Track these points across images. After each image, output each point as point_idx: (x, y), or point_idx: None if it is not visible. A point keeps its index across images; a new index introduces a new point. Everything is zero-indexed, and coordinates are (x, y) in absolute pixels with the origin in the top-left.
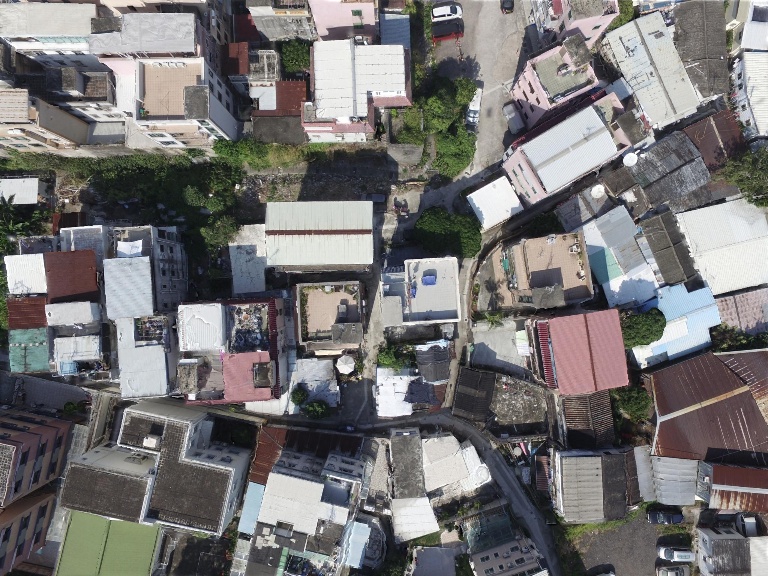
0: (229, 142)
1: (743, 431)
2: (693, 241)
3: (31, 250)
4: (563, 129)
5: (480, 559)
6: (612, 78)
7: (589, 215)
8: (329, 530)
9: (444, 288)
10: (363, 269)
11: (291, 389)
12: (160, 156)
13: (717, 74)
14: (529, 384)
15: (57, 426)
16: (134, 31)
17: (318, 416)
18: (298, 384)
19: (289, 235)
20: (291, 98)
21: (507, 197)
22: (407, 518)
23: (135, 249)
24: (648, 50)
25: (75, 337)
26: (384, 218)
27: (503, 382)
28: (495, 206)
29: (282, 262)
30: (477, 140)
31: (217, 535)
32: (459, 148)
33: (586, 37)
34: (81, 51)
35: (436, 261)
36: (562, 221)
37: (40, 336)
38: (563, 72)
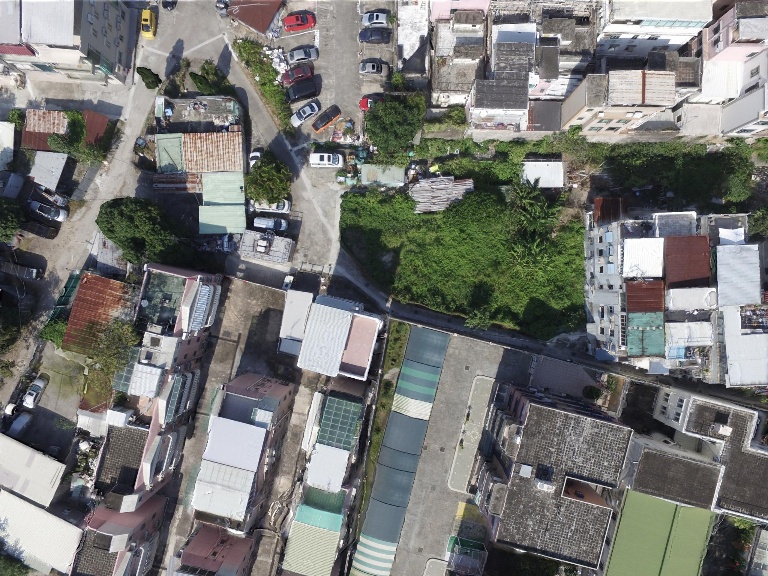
0: None
1: None
2: None
3: None
4: None
5: None
6: None
7: None
8: None
9: None
10: None
11: None
12: (685, 144)
13: None
14: None
15: None
16: None
17: None
18: None
19: None
20: None
21: None
22: None
23: (739, 237)
24: None
25: (687, 323)
26: None
27: None
28: None
29: None
30: None
31: None
32: None
33: None
34: (660, 36)
35: None
36: None
37: (656, 320)
38: None
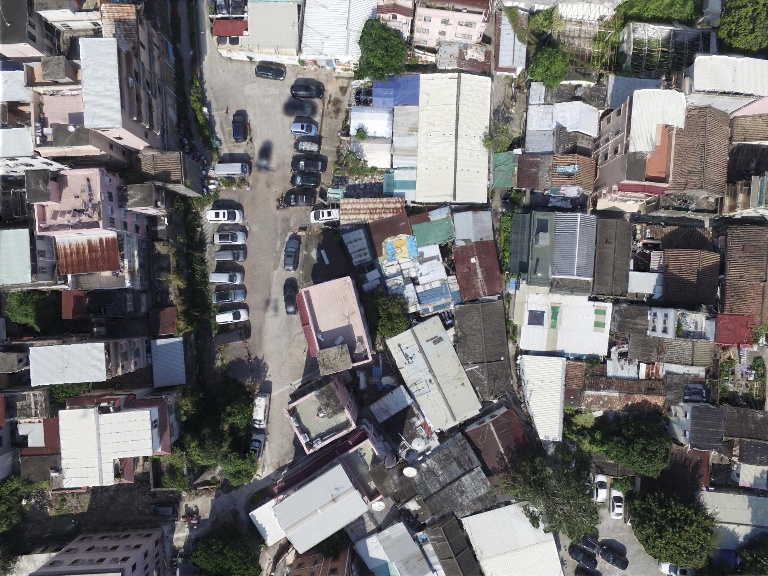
0: None
1: None
2: (478, 547)
3: None
4: (312, 489)
5: None
6: (400, 373)
7: (373, 526)
8: None
9: None
10: None
11: None
12: None
13: (497, 376)
14: None
15: None
16: None
17: None
18: None
19: None
20: None
21: None
22: None
23: None
24: (426, 358)
25: None
26: (175, 526)
27: None
28: None
29: None
30: (267, 441)
31: None
32: (238, 467)
33: None
34: None
35: None
36: (348, 531)
37: None
38: (321, 415)
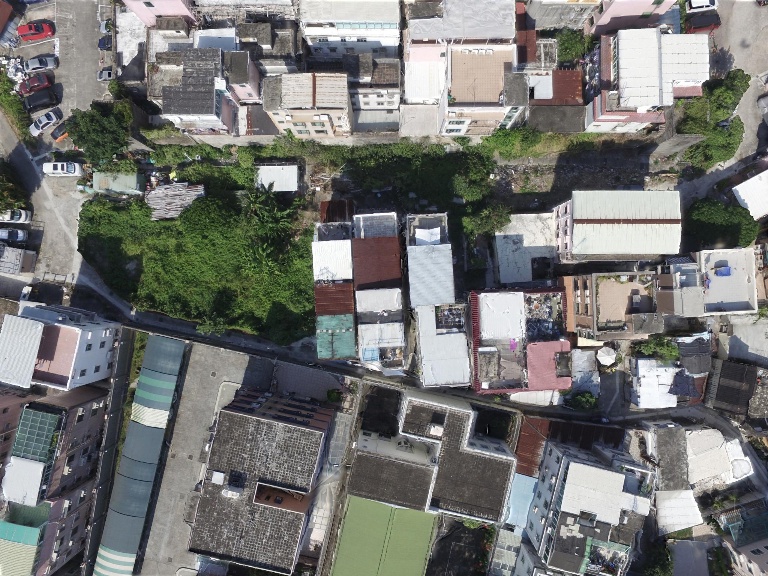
0: (507, 131)
1: None
2: None
3: (327, 236)
4: None
5: (751, 552)
6: None
7: None
8: (632, 520)
9: (735, 279)
10: None
11: None
12: (419, 145)
13: None
14: None
15: (328, 414)
16: (458, 17)
17: (590, 407)
18: None
19: (598, 224)
20: (567, 87)
21: None
22: (671, 510)
23: (434, 236)
24: None
25: (379, 324)
26: None
27: None
28: (760, 198)
29: (587, 251)
30: None
31: (484, 525)
32: (726, 140)
33: None
34: (366, 38)
35: (728, 252)
36: None
37: (346, 322)
38: None
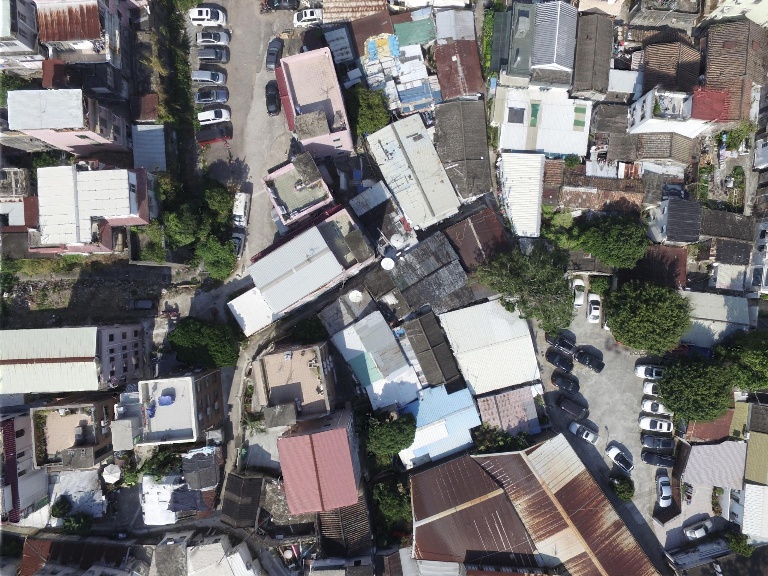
0: None
1: (500, 533)
2: (454, 342)
3: None
4: (288, 250)
5: None
6: (381, 177)
7: (351, 319)
8: None
9: (183, 406)
10: (108, 387)
11: (53, 501)
12: None
13: (477, 175)
14: None
15: None
16: None
17: (74, 531)
18: (61, 496)
19: (11, 364)
20: None
21: None
22: None
23: None
24: (406, 153)
25: None
26: (154, 323)
27: (277, 483)
28: (256, 312)
29: (7, 390)
30: (248, 242)
31: None
32: (217, 256)
33: (335, 146)
34: None
35: None
36: (326, 324)
37: None
38: (298, 188)
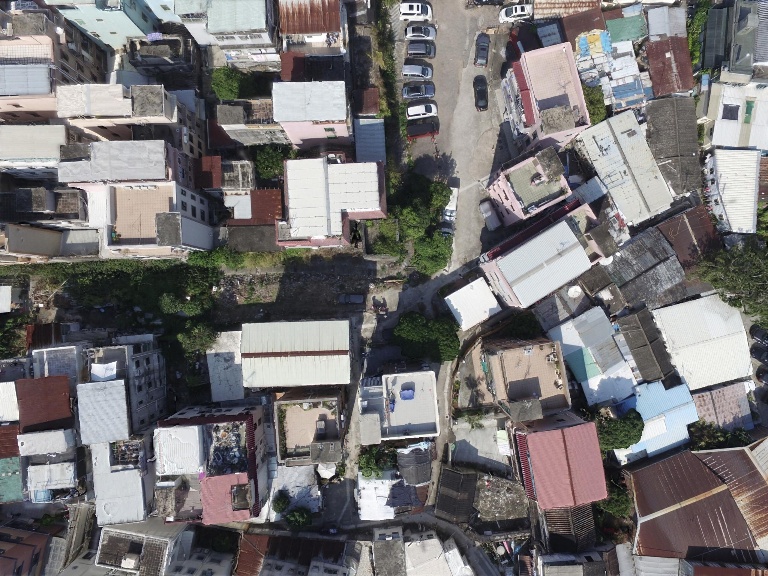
0: (204, 253)
1: (722, 529)
2: (669, 338)
3: (3, 374)
4: (537, 244)
5: None
6: (587, 173)
7: (566, 314)
8: None
9: (422, 401)
10: None
11: (272, 496)
12: (135, 261)
13: (689, 171)
14: (511, 482)
15: (33, 543)
16: (104, 160)
17: (299, 526)
18: (279, 491)
19: (265, 357)
20: (266, 207)
21: (485, 298)
22: None
23: (109, 372)
24: (621, 149)
25: (49, 465)
26: (363, 317)
27: (485, 479)
28: (473, 307)
29: (258, 384)
30: (454, 237)
31: None
32: (436, 250)
33: (559, 141)
34: (52, 166)
35: (414, 374)
36: (540, 320)
37: (13, 465)
38: (536, 182)
